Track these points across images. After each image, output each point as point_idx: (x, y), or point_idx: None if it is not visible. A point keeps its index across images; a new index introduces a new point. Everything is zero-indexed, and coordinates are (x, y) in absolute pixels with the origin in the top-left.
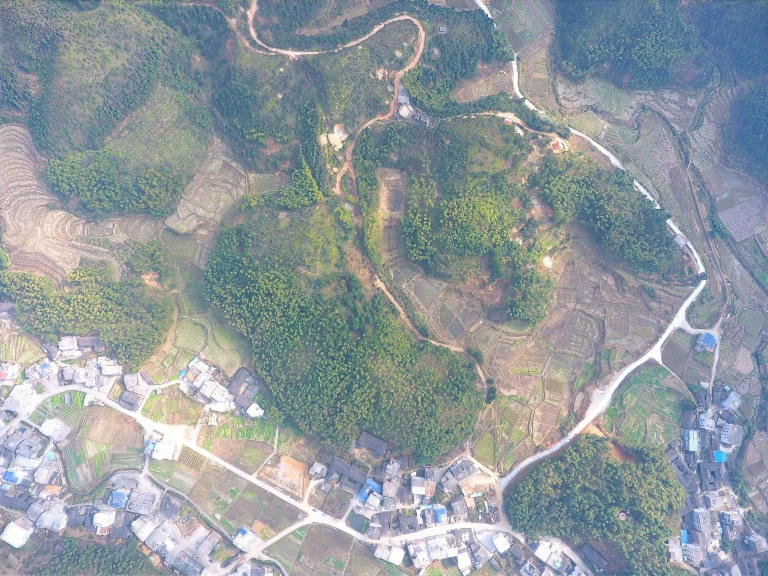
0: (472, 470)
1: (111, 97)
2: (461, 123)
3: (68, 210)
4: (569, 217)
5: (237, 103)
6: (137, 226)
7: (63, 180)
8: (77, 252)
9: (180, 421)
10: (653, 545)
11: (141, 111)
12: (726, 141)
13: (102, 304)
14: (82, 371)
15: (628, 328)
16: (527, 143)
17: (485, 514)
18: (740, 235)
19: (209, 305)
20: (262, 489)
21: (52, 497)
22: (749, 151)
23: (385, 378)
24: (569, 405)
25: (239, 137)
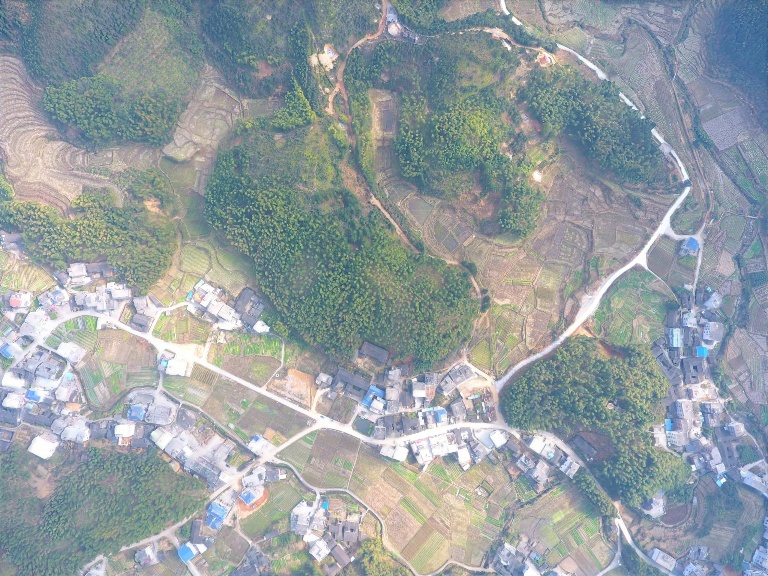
0: (469, 374)
1: (101, 22)
2: (449, 39)
3: (67, 140)
4: (557, 130)
5: (227, 26)
6: (136, 155)
7: (60, 108)
8: (79, 181)
9: (190, 340)
10: (639, 429)
11: (132, 37)
12: (710, 52)
13: (107, 228)
14: (93, 296)
15: (615, 237)
16: (515, 57)
17: (482, 414)
18: (723, 144)
19: (211, 229)
20: (272, 400)
21: (74, 413)
22: (732, 60)
23: (384, 286)
24: (560, 311)
25: (230, 62)
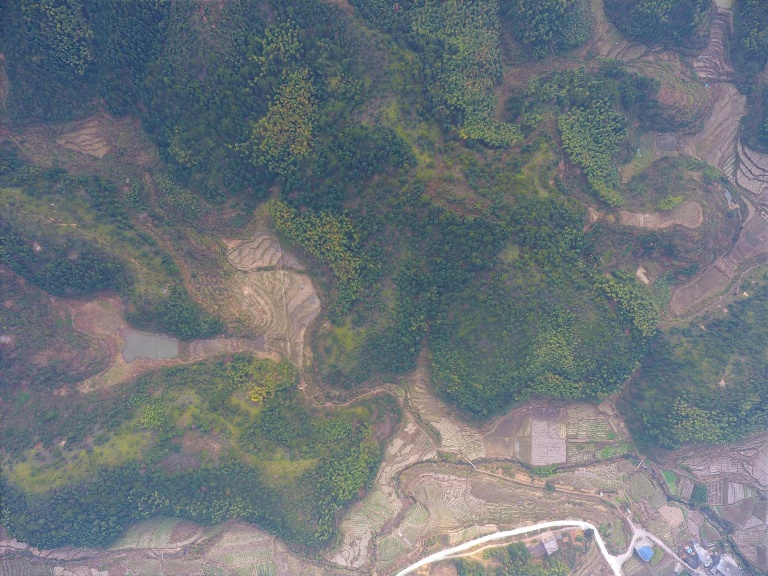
0: None
1: None
2: None
3: None
4: None
5: None
6: None
7: None
8: None
9: None
10: None
11: None
12: (467, 424)
13: None
14: None
15: None
16: None
17: None
18: (561, 455)
19: None
20: None
21: None
22: None
23: None
24: None
25: None
